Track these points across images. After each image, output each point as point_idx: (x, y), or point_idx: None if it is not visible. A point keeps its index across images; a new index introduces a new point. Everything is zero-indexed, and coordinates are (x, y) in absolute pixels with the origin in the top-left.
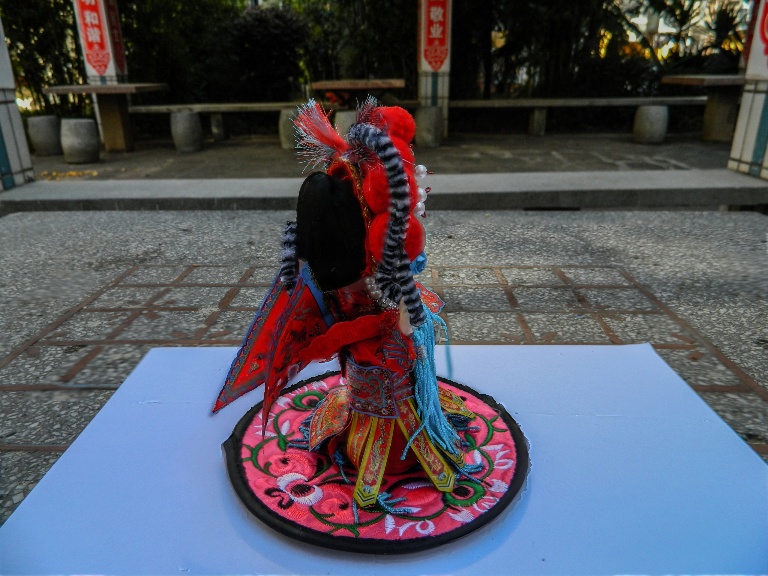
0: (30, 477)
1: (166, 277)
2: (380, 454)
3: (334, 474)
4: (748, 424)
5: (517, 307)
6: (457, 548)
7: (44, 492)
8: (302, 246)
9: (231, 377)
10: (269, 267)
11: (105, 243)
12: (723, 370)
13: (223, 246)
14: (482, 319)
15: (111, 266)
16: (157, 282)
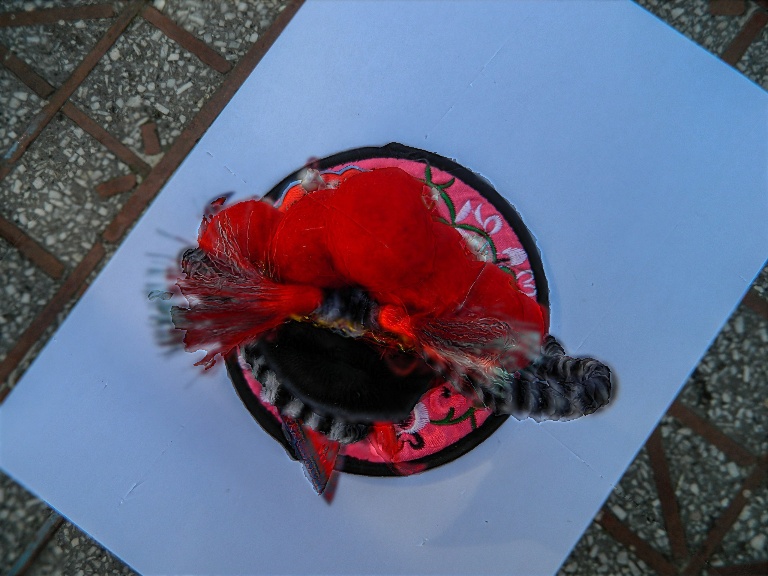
0: None
1: None
2: None
3: None
4: None
5: None
6: None
7: None
8: None
9: None
10: None
11: None
12: None
13: None
14: None
15: None
16: None
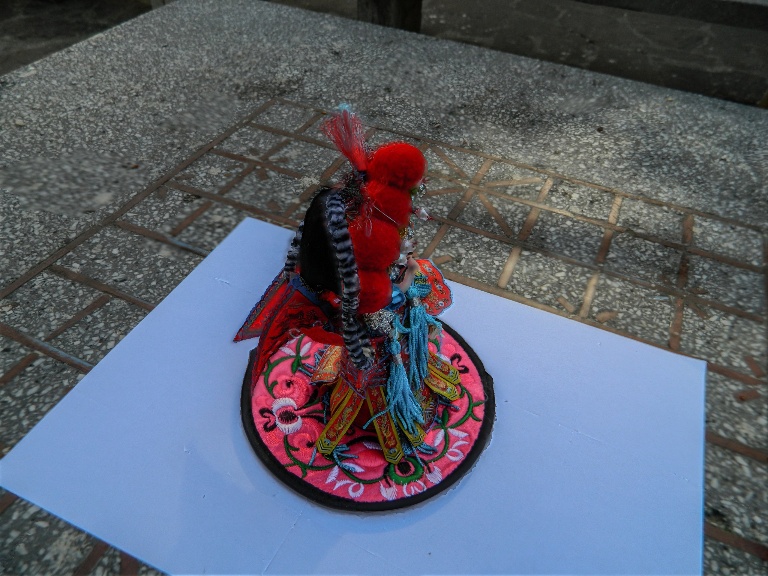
0: (123, 328)
1: (293, 123)
2: (347, 419)
3: (319, 410)
4: (726, 500)
5: (601, 263)
6: (371, 516)
7: (127, 346)
8: (300, 255)
9: (249, 321)
10: (389, 132)
11: (260, 58)
12: (762, 425)
13: (360, 88)
14: (553, 270)
15: (253, 94)
16: (283, 128)
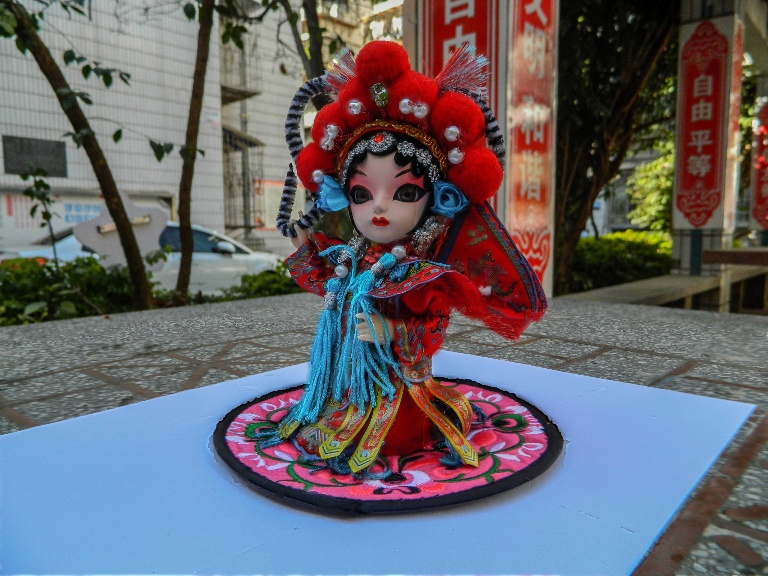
0: (524, 362)
1: None
2: None
3: None
4: None
5: None
6: None
7: None
8: None
9: None
10: None
11: None
12: None
13: None
14: None
15: None
16: None
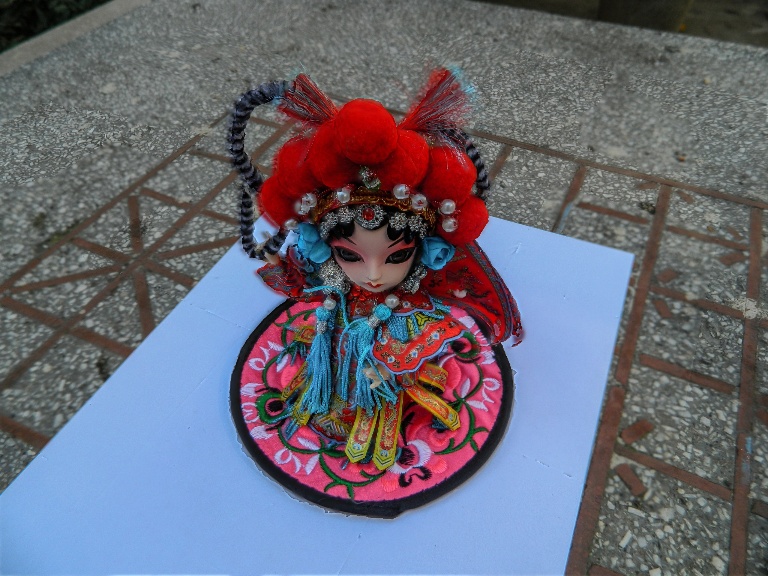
0: None
1: None
2: None
3: None
4: None
5: None
6: None
7: None
8: None
9: None
10: None
11: None
12: None
13: None
14: None
15: None
16: None
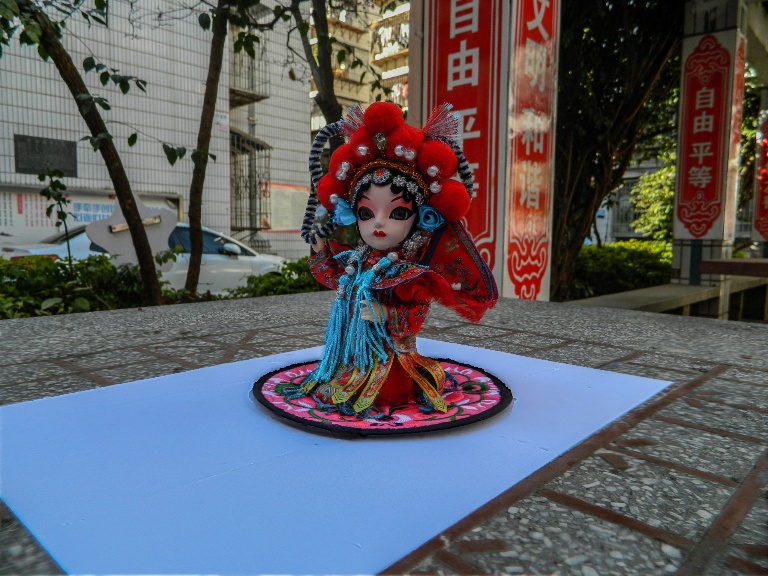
0: None
1: None
2: None
3: None
4: None
5: None
6: None
7: None
8: None
9: None
10: None
11: None
12: None
13: None
14: (606, 567)
15: None
16: None
